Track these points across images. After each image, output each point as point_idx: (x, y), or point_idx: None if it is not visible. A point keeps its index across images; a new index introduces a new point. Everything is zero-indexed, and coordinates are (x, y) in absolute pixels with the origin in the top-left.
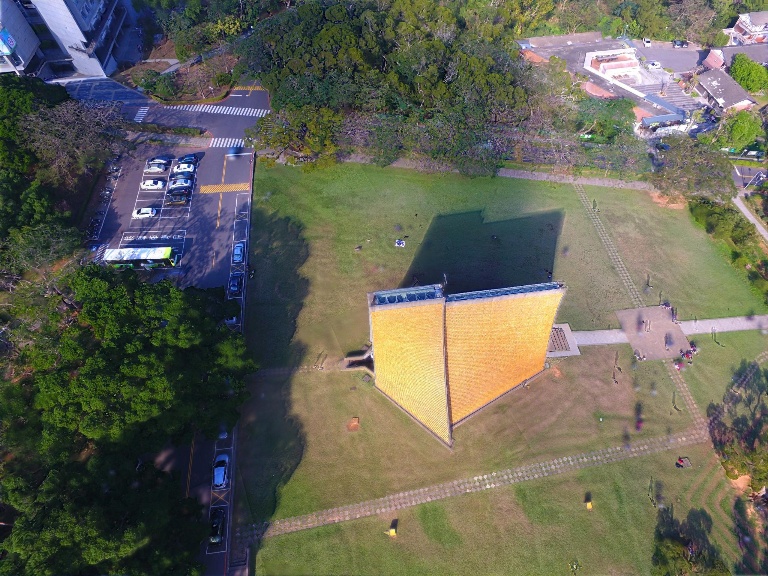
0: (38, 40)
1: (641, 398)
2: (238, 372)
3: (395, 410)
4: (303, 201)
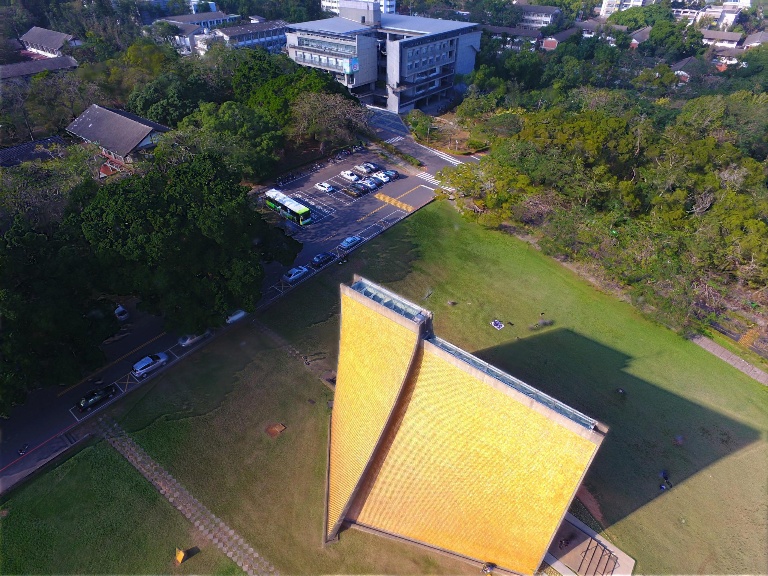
0: (376, 78)
1: None
2: (235, 299)
3: (322, 453)
4: (444, 242)
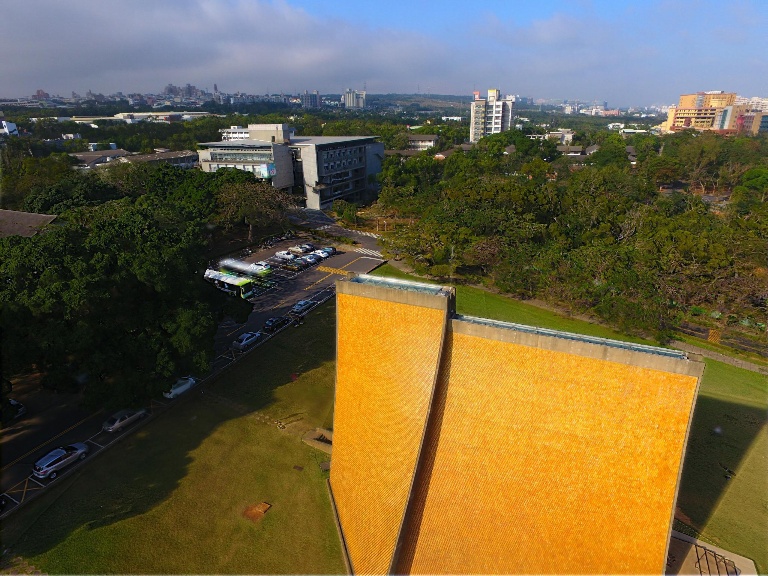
0: (293, 183)
1: None
2: (181, 359)
3: (328, 525)
4: None
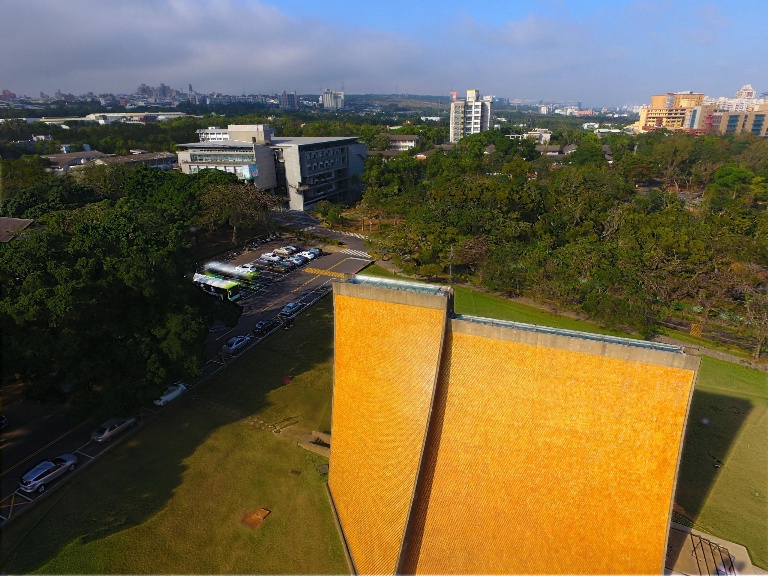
0: (276, 184)
1: None
2: (172, 365)
3: (330, 529)
4: None
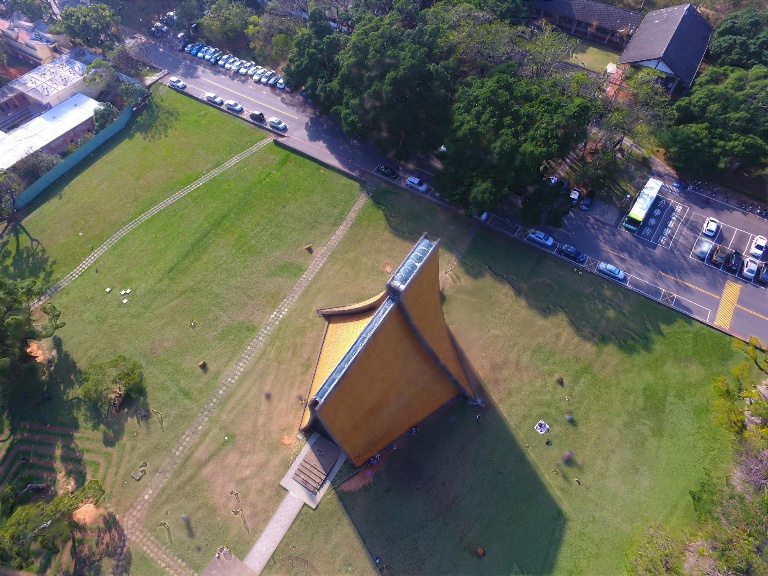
0: None
1: (201, 501)
2: None
3: None
4: (669, 368)
